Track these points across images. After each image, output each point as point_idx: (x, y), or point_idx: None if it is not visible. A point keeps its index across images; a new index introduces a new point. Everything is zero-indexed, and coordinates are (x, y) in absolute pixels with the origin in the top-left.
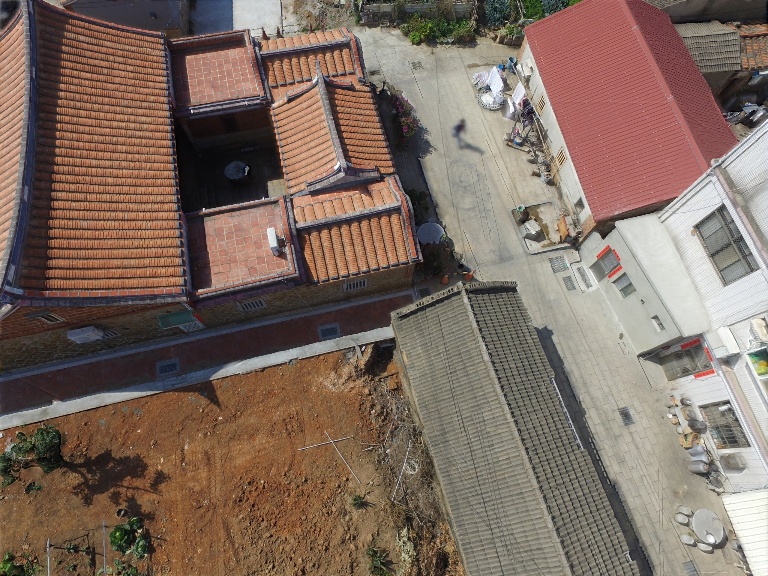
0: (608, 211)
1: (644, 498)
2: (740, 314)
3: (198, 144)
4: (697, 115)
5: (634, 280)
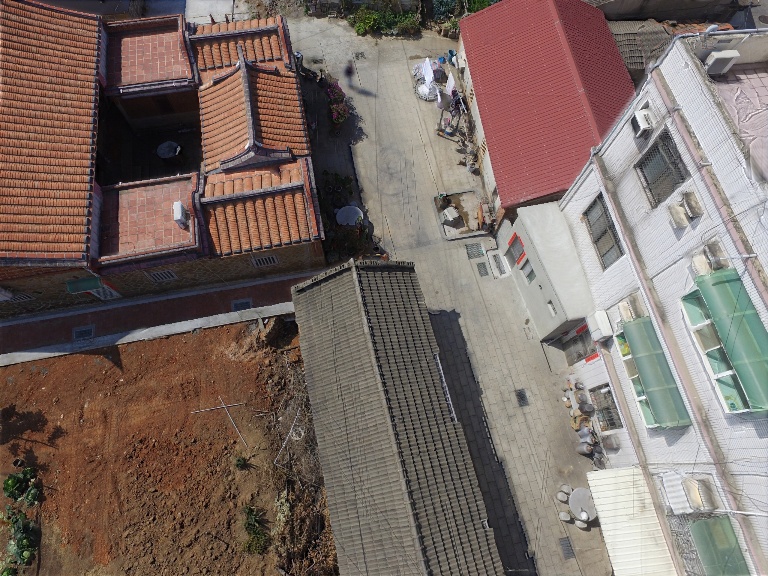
0: (515, 199)
1: (529, 476)
2: (613, 298)
3: (135, 124)
4: (610, 109)
5: (534, 266)
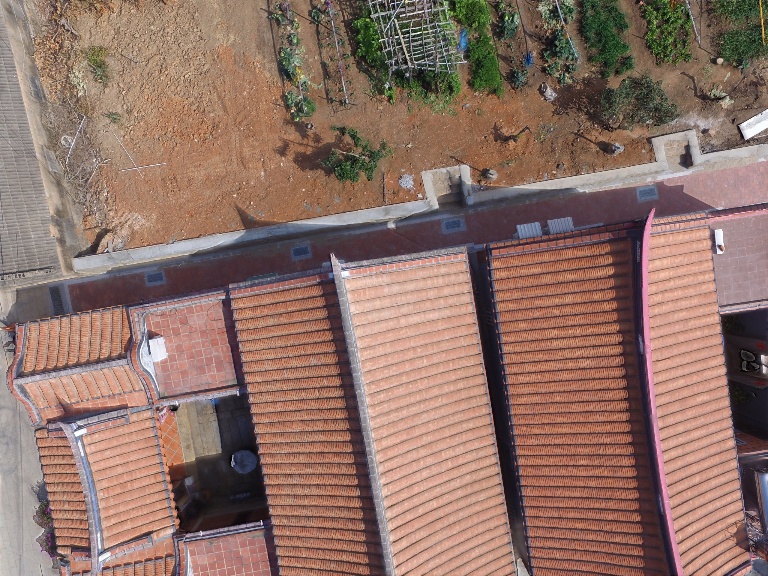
0: None
1: None
2: None
3: None
4: None
5: None
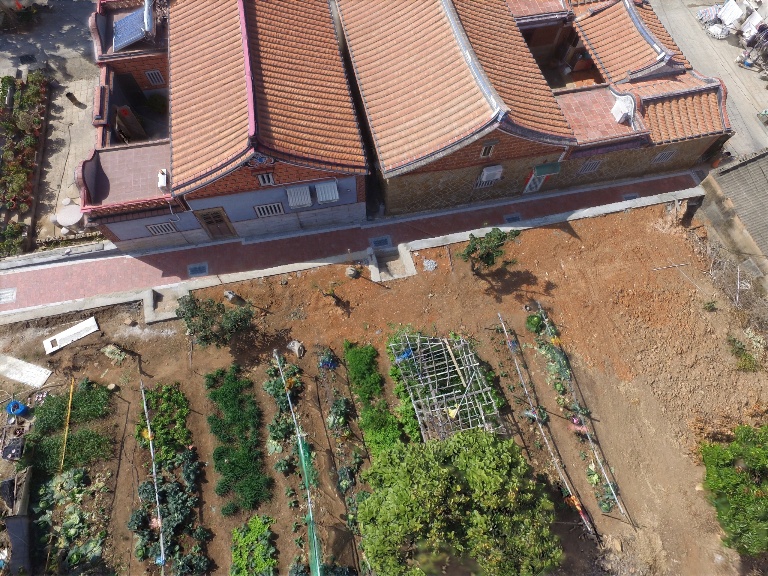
0: None
1: None
2: None
3: None
4: None
5: None
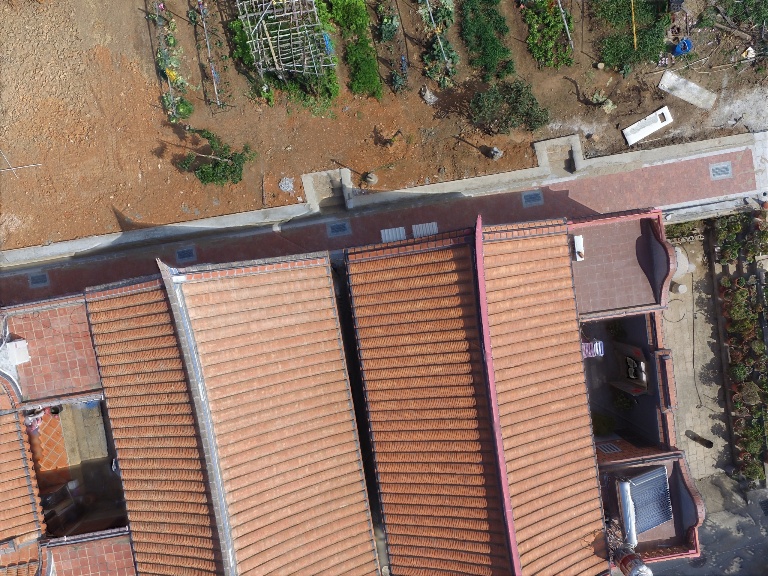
0: None
1: None
2: None
3: None
4: None
5: None
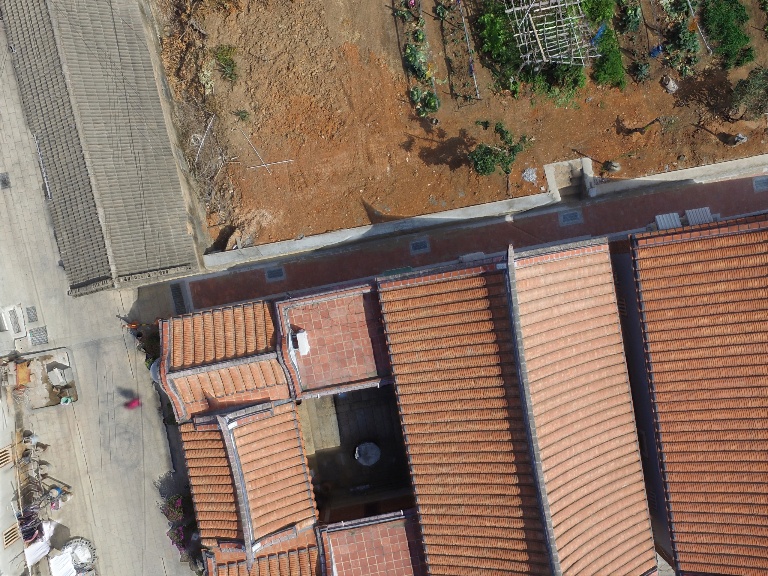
0: None
1: (6, 111)
2: None
3: (412, 491)
4: None
5: None
